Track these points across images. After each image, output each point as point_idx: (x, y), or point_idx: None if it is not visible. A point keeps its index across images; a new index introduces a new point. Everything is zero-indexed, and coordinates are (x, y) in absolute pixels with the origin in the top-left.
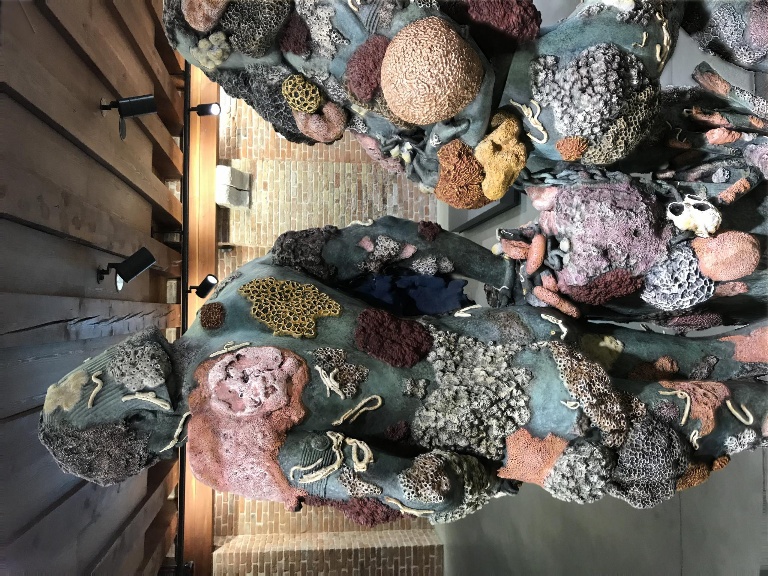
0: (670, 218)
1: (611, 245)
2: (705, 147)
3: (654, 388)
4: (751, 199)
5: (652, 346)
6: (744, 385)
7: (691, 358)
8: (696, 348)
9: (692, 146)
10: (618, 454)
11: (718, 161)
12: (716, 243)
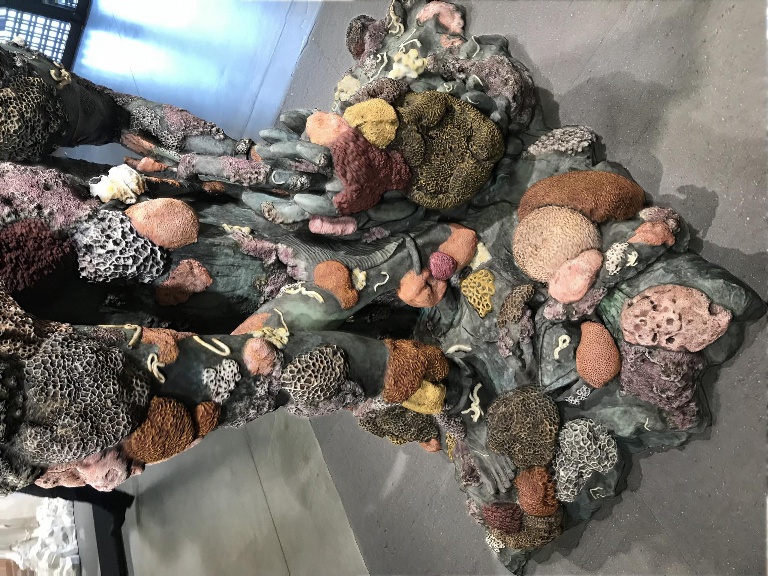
0: (95, 194)
1: (14, 193)
2: None
3: None
4: None
5: None
6: None
7: None
8: None
9: None
10: (23, 362)
11: None
12: (144, 203)
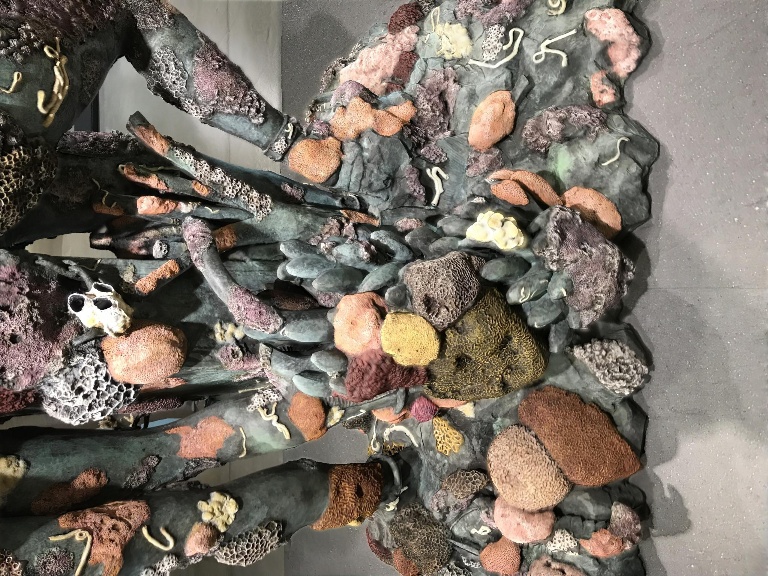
0: (73, 312)
1: None
2: (142, 214)
3: (45, 532)
4: (188, 280)
5: (72, 459)
6: (171, 499)
7: (127, 463)
8: (136, 448)
9: (124, 213)
10: None
11: (166, 227)
12: (127, 344)
